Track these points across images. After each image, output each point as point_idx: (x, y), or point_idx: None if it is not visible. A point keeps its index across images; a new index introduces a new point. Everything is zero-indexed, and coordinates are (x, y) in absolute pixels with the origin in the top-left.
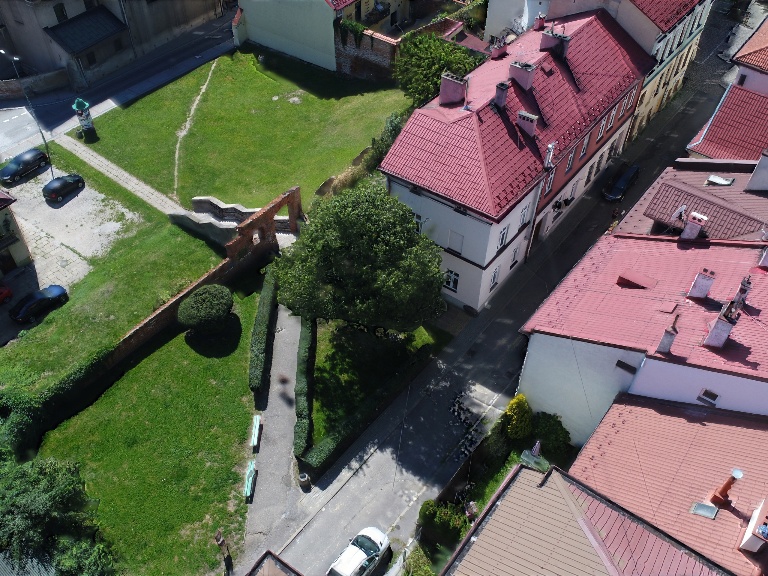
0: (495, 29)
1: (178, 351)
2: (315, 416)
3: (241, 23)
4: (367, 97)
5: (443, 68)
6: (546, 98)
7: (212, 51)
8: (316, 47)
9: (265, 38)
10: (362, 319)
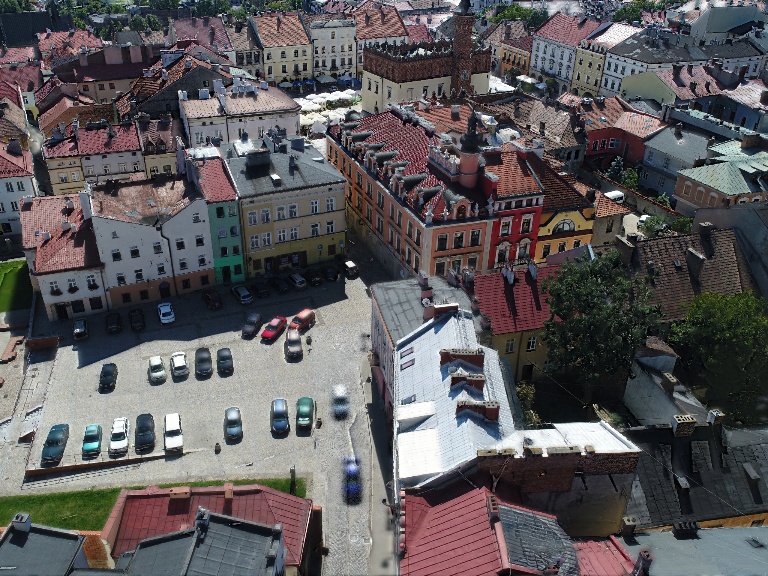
0: None
1: None
2: None
3: None
4: None
5: None
6: None
7: None
8: None
9: None
10: None
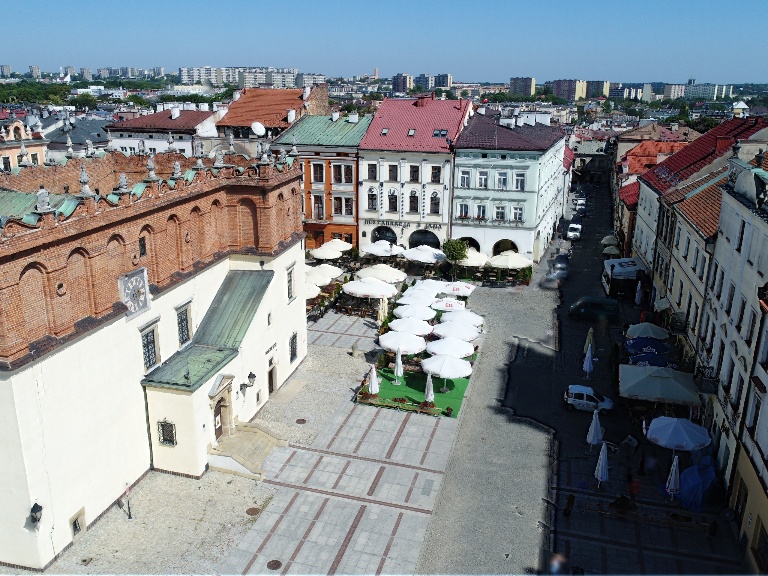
0: None
1: None
2: None
3: None
4: None
5: None
6: None
7: None
8: None
9: None
10: None
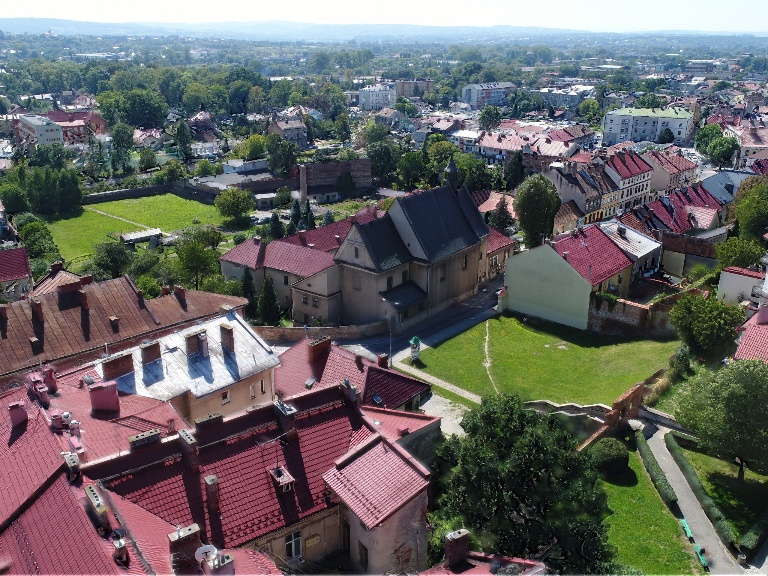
0: (725, 299)
1: None
2: None
3: (505, 296)
4: (623, 346)
5: (722, 313)
6: None
7: (481, 315)
8: (571, 312)
9: (523, 307)
10: (766, 444)
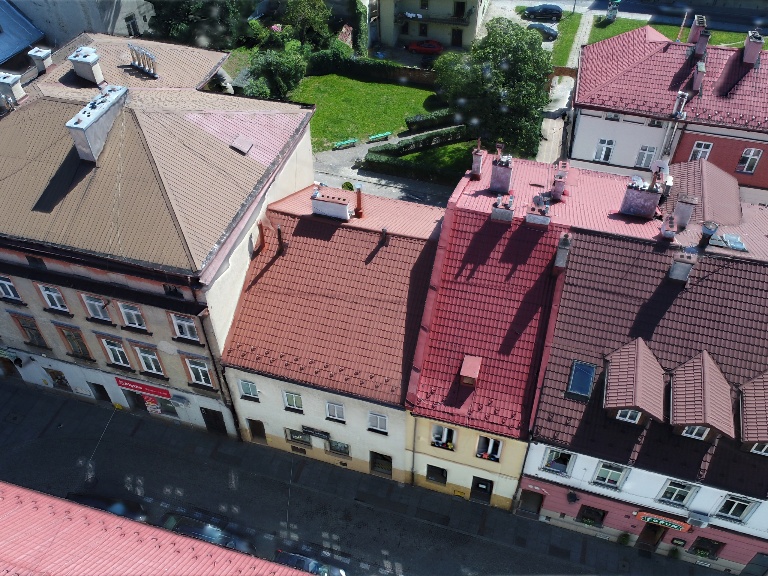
0: None
1: (420, 95)
2: (408, 156)
3: None
4: None
5: None
6: (760, 82)
7: None
8: None
9: None
10: None
